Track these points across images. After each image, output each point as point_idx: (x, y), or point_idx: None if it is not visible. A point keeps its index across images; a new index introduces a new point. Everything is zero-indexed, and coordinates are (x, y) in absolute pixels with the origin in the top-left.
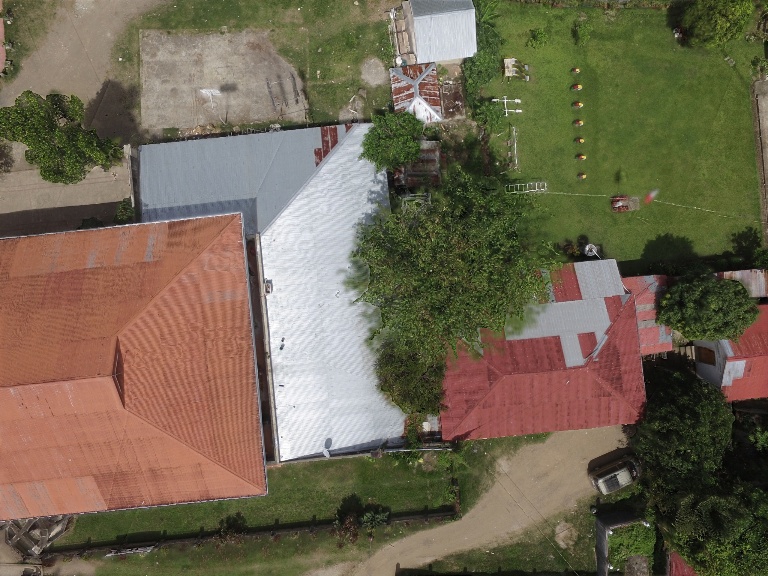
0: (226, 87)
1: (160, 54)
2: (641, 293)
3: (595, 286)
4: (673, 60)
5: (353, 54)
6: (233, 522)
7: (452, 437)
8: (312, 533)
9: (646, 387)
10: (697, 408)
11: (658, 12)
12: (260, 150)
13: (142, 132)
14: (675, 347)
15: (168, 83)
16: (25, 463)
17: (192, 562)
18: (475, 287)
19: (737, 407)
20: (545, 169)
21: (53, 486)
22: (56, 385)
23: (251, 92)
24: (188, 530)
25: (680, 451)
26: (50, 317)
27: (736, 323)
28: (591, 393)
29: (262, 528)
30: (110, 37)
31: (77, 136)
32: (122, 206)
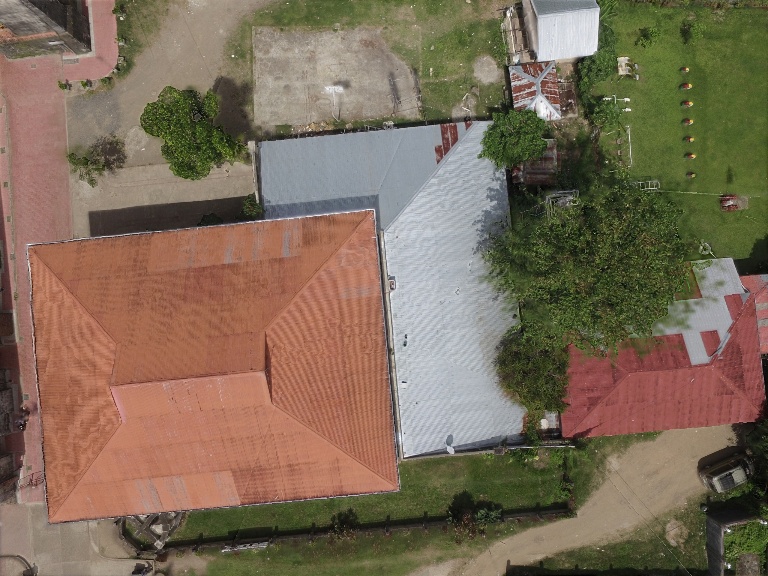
0: (339, 84)
1: (273, 51)
2: (760, 292)
3: (714, 284)
4: None
5: (466, 52)
6: (345, 518)
7: (573, 434)
8: (427, 530)
9: None
10: None
11: (767, 12)
12: (380, 147)
13: (255, 129)
14: None
15: (281, 80)
16: (166, 458)
17: (303, 558)
18: (645, 284)
19: None
20: (654, 168)
21: (190, 481)
22: (208, 380)
23: (364, 89)
24: (300, 526)
25: None
26: (194, 312)
27: None
28: (714, 391)
29: (374, 524)
30: (222, 34)
31: (211, 132)
32: (249, 202)
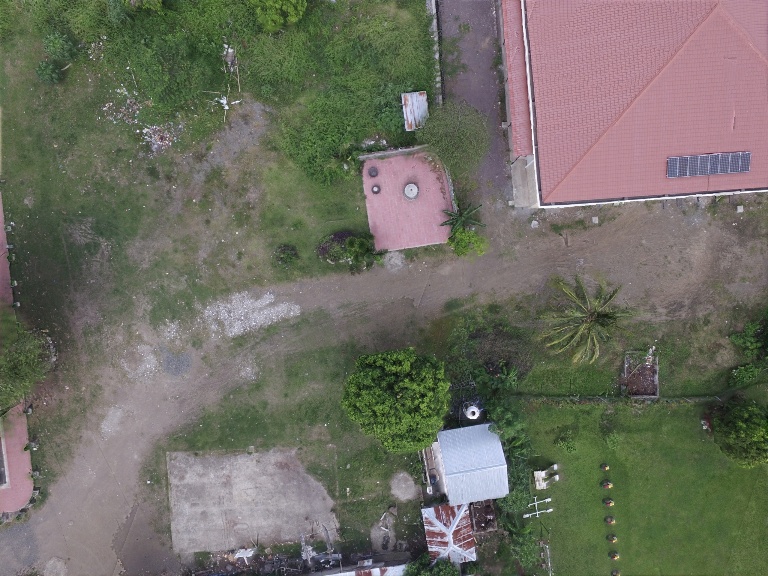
0: (256, 508)
1: (188, 477)
2: None
3: None
4: (702, 451)
5: (382, 469)
6: None
7: None
8: None
9: None
10: None
11: None
12: None
13: (173, 556)
14: None
15: (197, 506)
16: None
17: None
18: None
19: None
20: (578, 567)
21: None
22: None
23: (281, 512)
24: None
25: None
26: None
27: None
28: None
29: None
30: (137, 459)
31: None
32: None
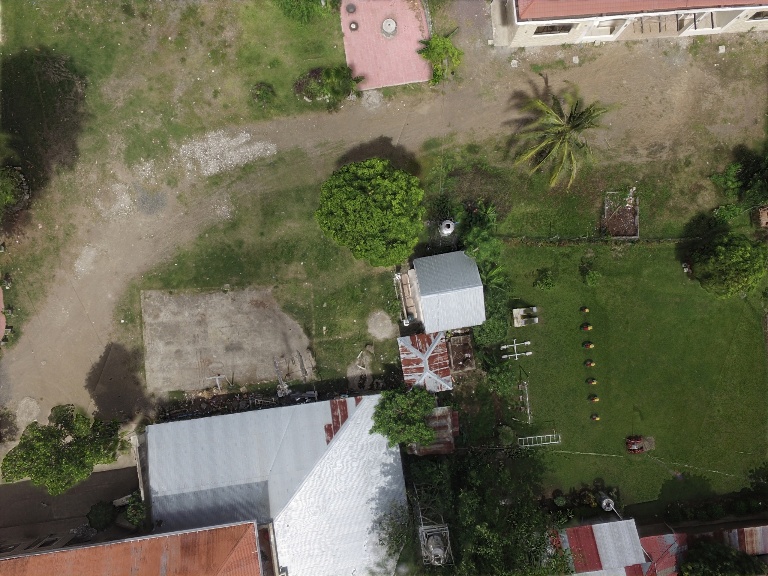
0: (231, 347)
1: (163, 315)
2: (661, 557)
3: (615, 553)
4: (683, 294)
5: (359, 308)
6: None
7: None
8: None
9: None
10: None
11: (666, 246)
12: (269, 428)
13: (147, 395)
14: None
15: (172, 345)
16: None
17: None
18: None
19: None
20: (558, 411)
21: None
22: None
23: (257, 351)
24: None
25: None
26: None
27: None
28: None
29: None
30: (111, 298)
31: (84, 452)
32: (132, 505)
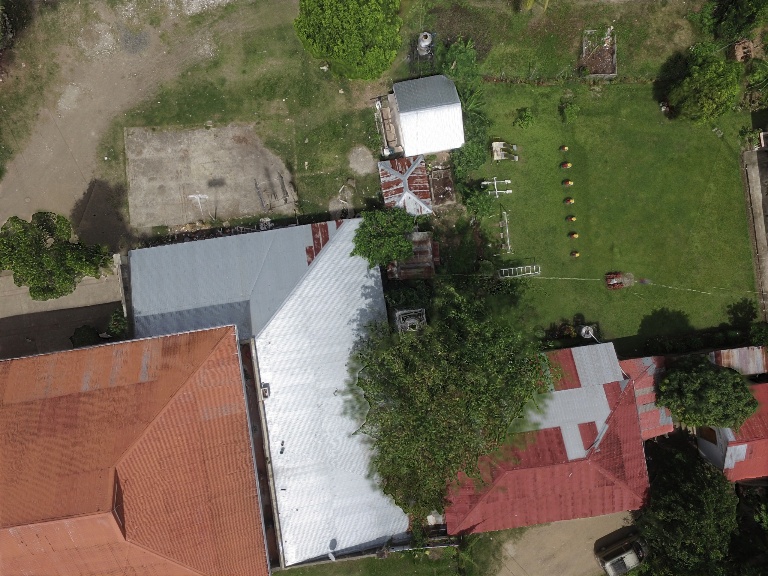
0: (214, 182)
1: (146, 152)
2: (640, 377)
3: (593, 372)
4: (661, 133)
5: (340, 143)
6: None
7: (457, 532)
8: None
9: (649, 464)
10: (701, 497)
11: (644, 86)
12: (251, 250)
13: (131, 231)
14: (676, 422)
15: (155, 181)
16: None
17: None
18: (474, 420)
19: (740, 480)
20: (538, 248)
21: None
22: (55, 523)
23: (239, 186)
24: None
25: (686, 543)
26: (46, 448)
27: (736, 415)
28: (594, 483)
29: None
30: (94, 136)
31: (65, 255)
32: (114, 318)
